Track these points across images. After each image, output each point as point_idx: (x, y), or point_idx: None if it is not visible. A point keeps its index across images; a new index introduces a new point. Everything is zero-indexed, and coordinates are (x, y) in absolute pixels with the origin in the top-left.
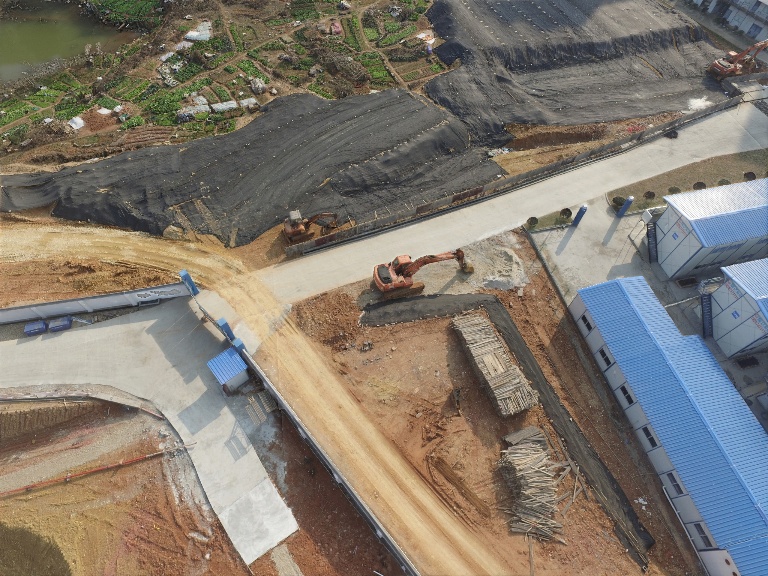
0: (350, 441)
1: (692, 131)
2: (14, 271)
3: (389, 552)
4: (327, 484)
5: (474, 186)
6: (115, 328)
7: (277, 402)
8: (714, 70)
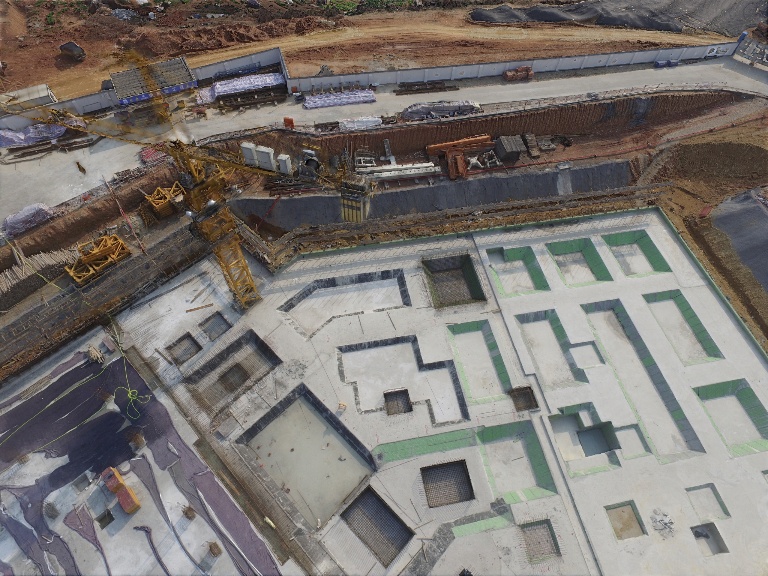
0: None
1: None
2: (610, 44)
3: None
4: None
5: None
6: (704, 66)
7: None
8: None
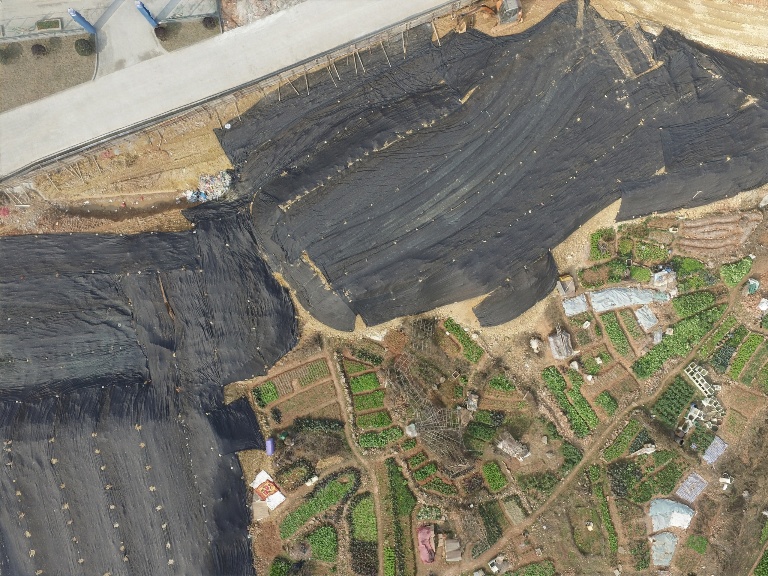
0: None
1: None
2: None
3: None
4: None
5: (267, 107)
6: None
7: None
8: None
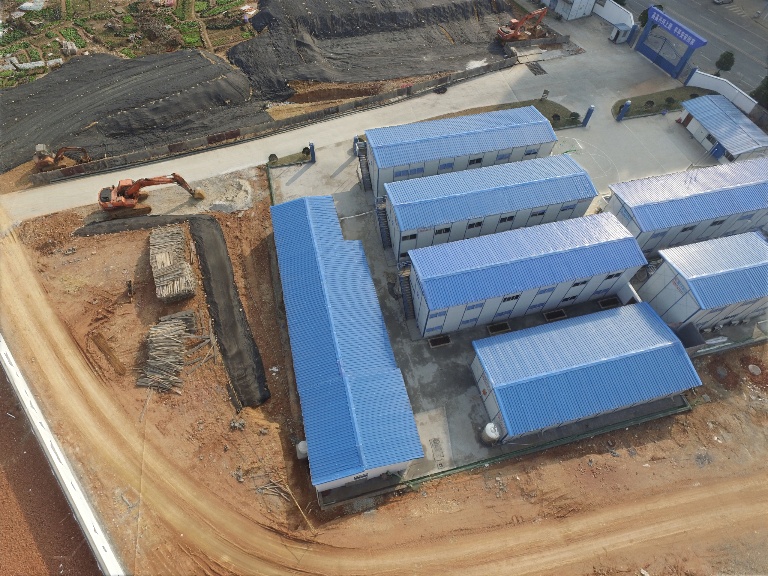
0: (26, 321)
1: (461, 88)
2: None
3: None
4: None
5: None
6: None
7: None
8: (498, 36)
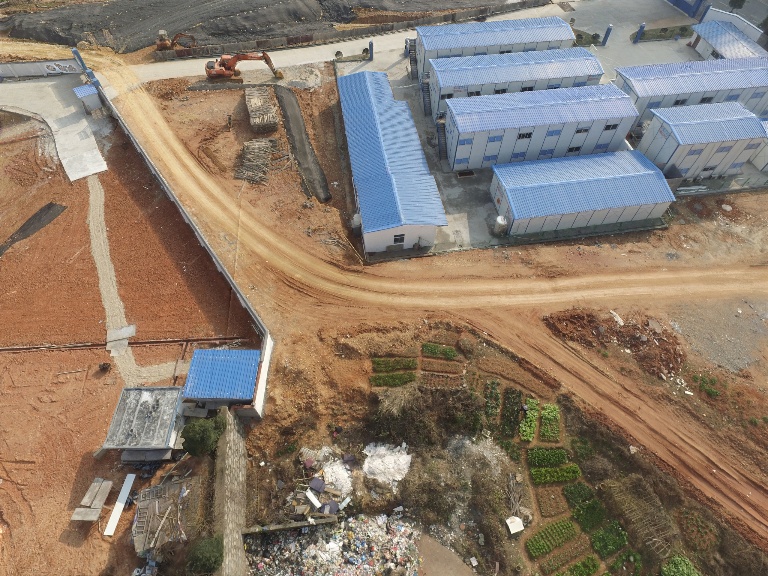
0: (154, 137)
1: (498, 18)
2: None
3: (157, 181)
4: (132, 153)
5: None
6: (29, 84)
7: (112, 111)
8: None
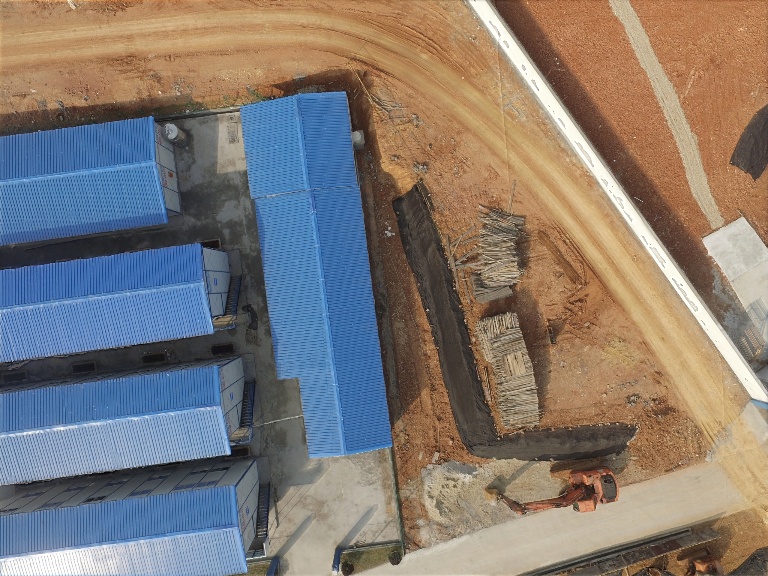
0: (656, 306)
1: None
2: None
3: None
4: None
5: None
6: None
7: None
8: None
